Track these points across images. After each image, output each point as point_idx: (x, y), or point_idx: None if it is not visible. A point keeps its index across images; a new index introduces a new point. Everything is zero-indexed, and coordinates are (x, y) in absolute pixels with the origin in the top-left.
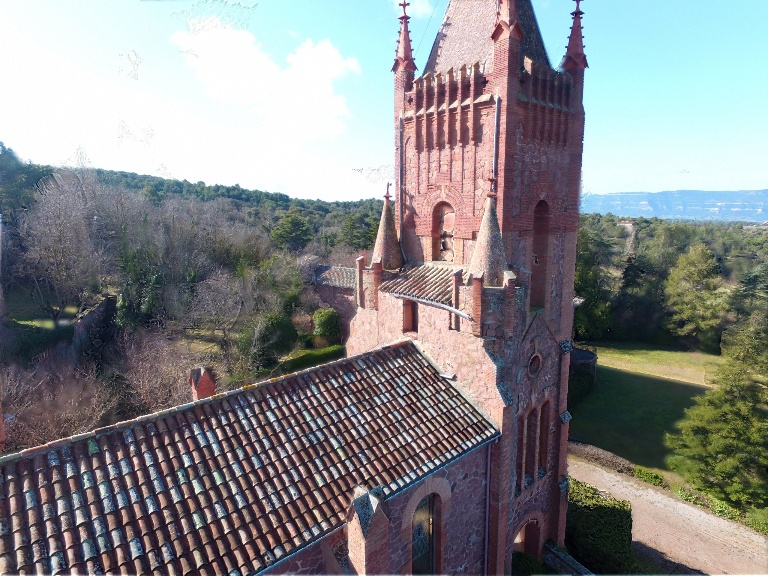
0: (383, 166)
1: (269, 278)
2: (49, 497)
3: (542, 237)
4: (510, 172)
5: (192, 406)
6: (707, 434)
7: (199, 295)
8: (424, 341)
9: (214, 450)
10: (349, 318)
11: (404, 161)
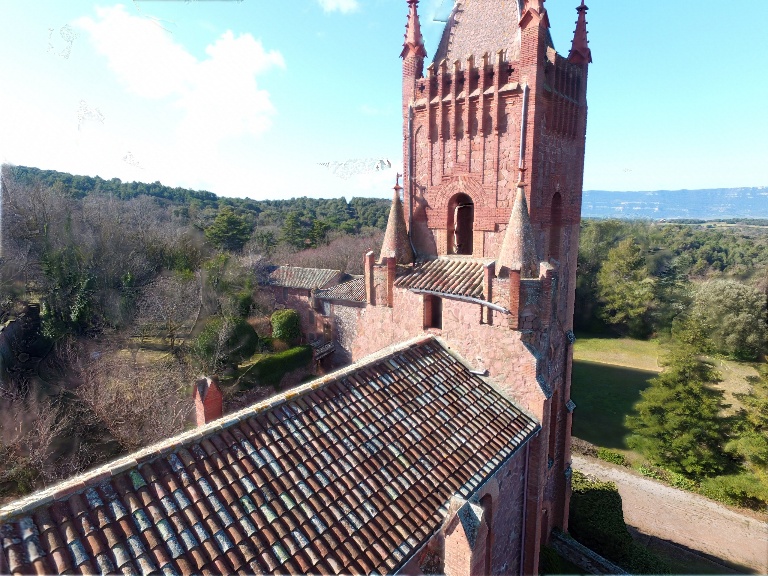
0: (350, 160)
1: (222, 279)
2: (101, 546)
3: (554, 229)
4: (536, 163)
5: (237, 422)
6: (663, 413)
7: (148, 299)
8: (449, 337)
9: (274, 470)
10: (301, 319)
11: (414, 151)
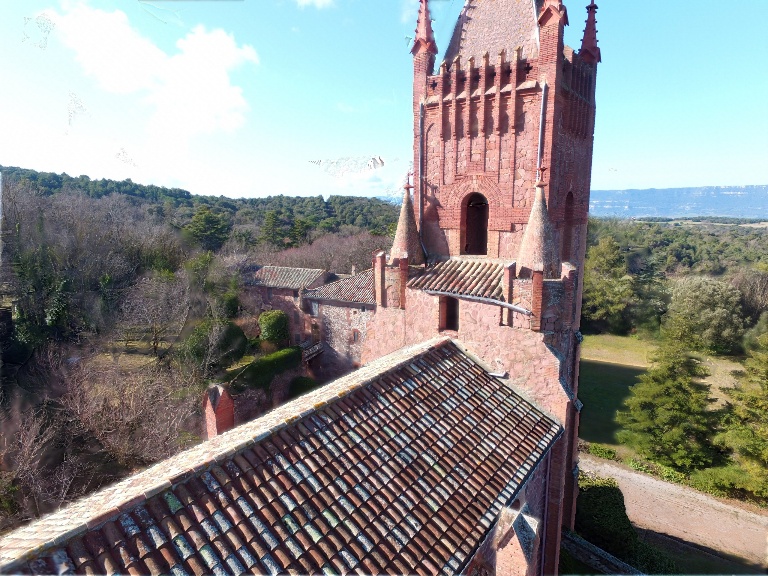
0: (342, 159)
1: (207, 280)
2: None
3: (565, 229)
4: (554, 162)
5: (269, 434)
6: (653, 408)
7: (132, 302)
8: (467, 339)
9: (313, 485)
10: None
11: (425, 150)
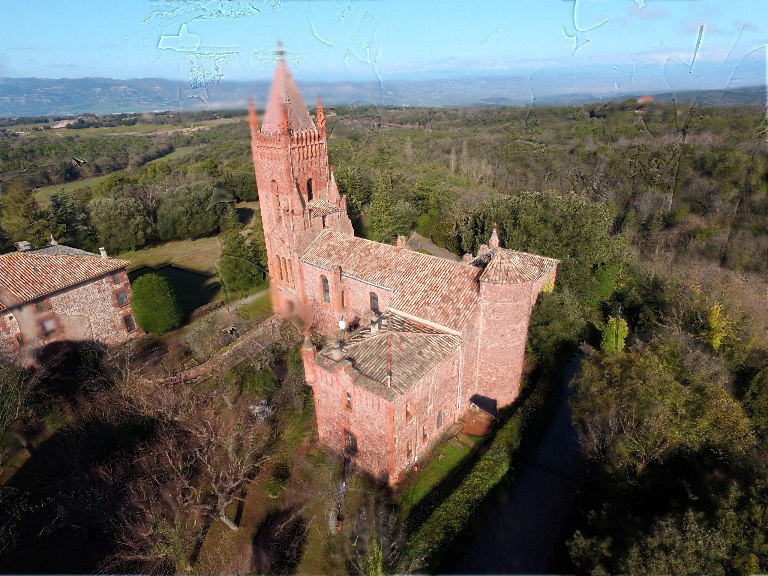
0: None
1: None
2: None
3: (309, 184)
4: None
5: None
6: None
7: None
8: None
9: None
10: None
11: None
